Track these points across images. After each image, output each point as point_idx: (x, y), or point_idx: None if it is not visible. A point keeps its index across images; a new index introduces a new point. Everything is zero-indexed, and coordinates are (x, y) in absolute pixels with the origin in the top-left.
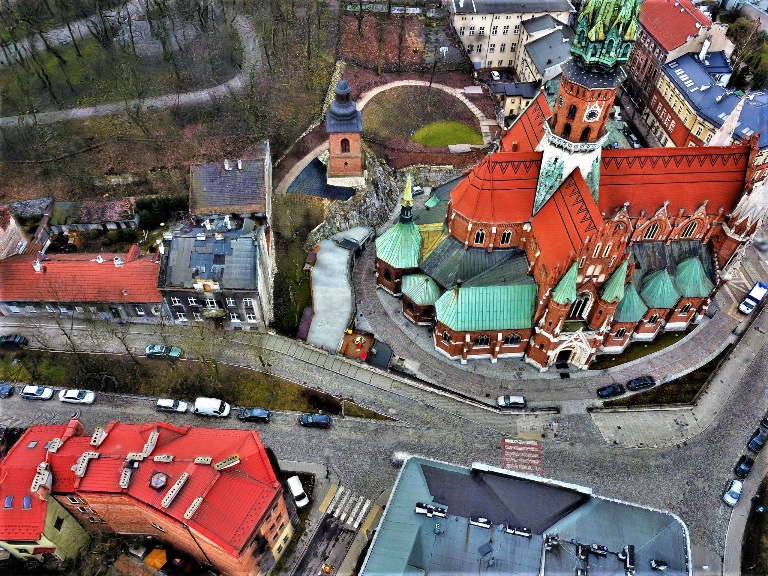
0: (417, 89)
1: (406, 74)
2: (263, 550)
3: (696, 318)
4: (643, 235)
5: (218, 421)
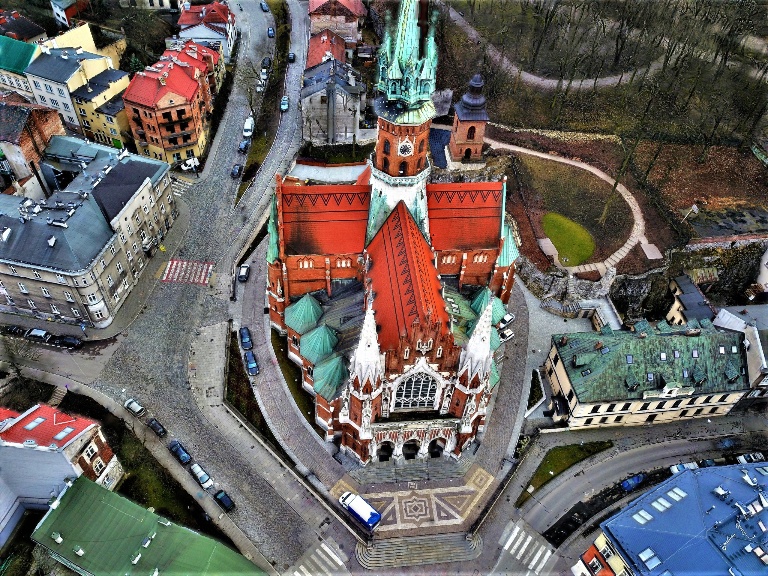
0: (621, 203)
1: (643, 193)
2: (134, 120)
3: None
4: None
5: (242, 134)
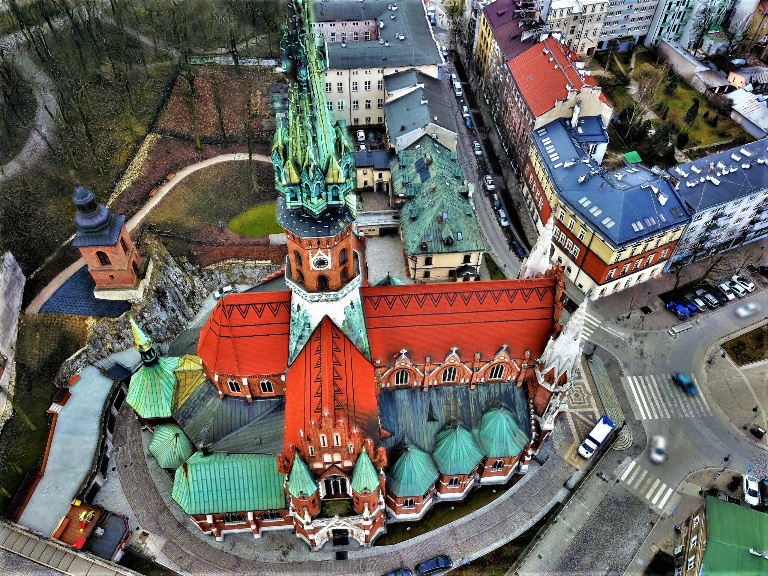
0: (243, 165)
1: (235, 146)
2: None
3: (521, 467)
4: (440, 379)
5: None
